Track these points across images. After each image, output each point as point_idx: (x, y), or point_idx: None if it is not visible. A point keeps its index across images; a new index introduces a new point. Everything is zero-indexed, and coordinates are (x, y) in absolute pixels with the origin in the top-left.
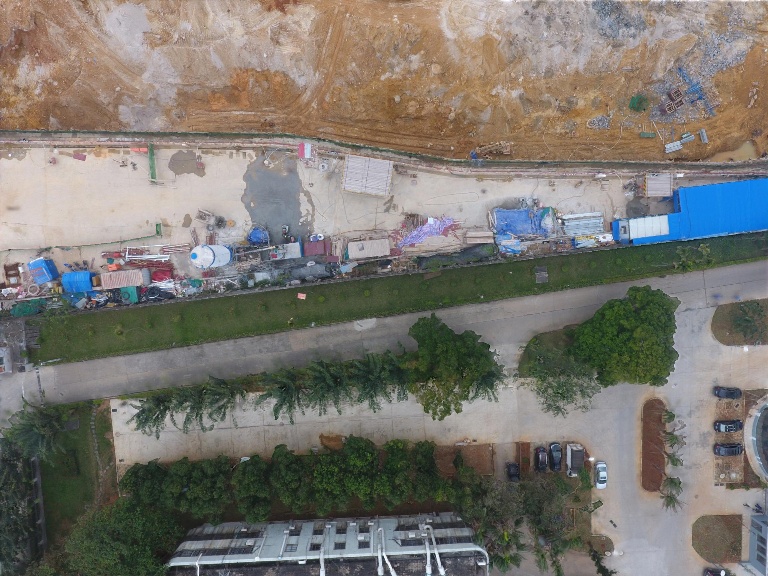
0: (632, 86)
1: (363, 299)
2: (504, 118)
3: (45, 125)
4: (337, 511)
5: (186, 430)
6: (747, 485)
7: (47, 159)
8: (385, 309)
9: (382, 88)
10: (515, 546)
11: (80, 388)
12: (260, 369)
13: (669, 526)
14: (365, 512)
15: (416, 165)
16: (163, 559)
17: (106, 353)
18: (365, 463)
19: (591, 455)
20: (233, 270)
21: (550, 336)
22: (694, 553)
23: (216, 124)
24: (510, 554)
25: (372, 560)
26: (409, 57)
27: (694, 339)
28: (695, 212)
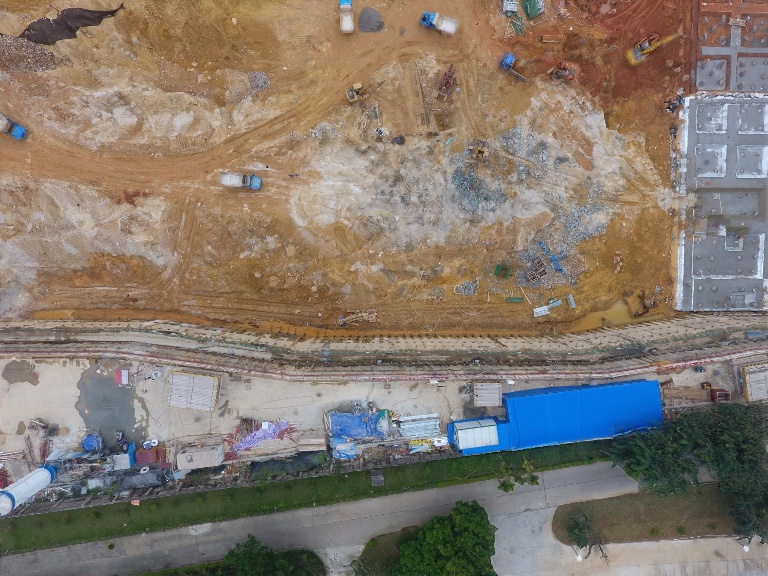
0: (496, 255)
1: (197, 504)
2: (367, 290)
3: None
4: None
5: None
6: None
7: None
8: (220, 514)
9: (240, 267)
10: None
11: None
12: (95, 574)
13: None
14: None
15: (248, 372)
16: None
17: None
18: None
19: None
20: (66, 477)
21: (388, 538)
22: None
23: (79, 299)
24: None
25: None
26: (266, 238)
27: (535, 539)
28: (524, 422)
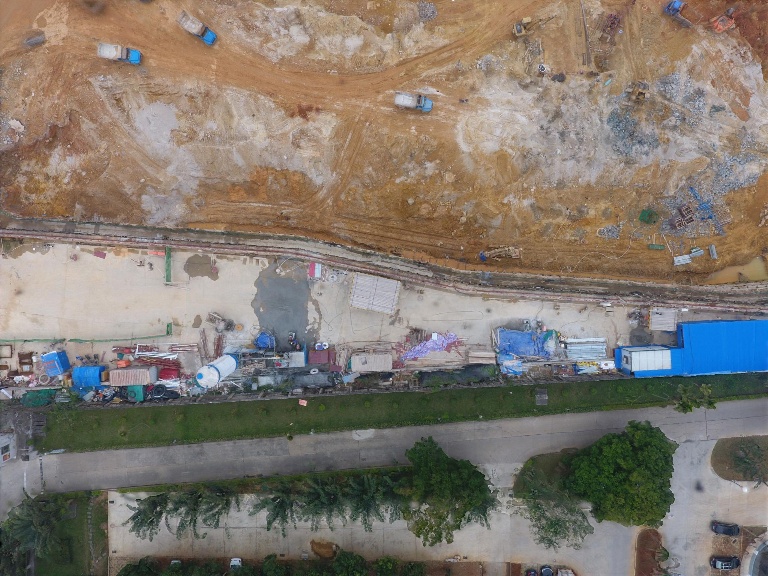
0: (643, 200)
1: (363, 409)
2: (514, 224)
3: (70, 212)
4: None
5: (179, 536)
6: None
7: (69, 255)
8: (384, 421)
9: (396, 191)
10: None
11: (80, 478)
12: (257, 471)
13: None
14: None
15: (423, 282)
16: None
17: (108, 446)
18: None
19: None
20: (238, 373)
21: (547, 458)
22: None
23: (234, 214)
24: None
25: None
26: (425, 164)
27: (693, 471)
28: (698, 349)
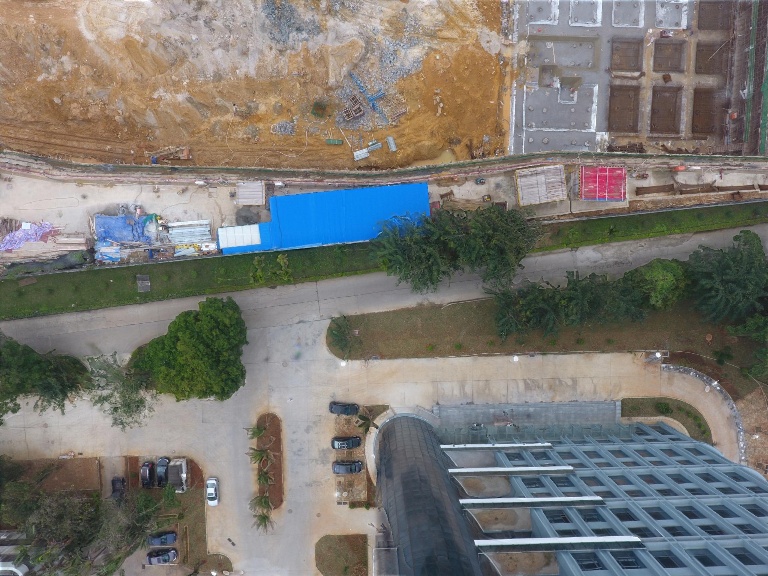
0: (311, 92)
1: None
2: (175, 122)
3: None
4: None
5: None
6: (368, 504)
7: None
8: None
9: (37, 89)
10: (70, 565)
11: None
12: None
13: (291, 545)
14: None
15: None
16: None
17: None
18: None
19: (204, 470)
20: None
21: None
22: (318, 573)
23: None
24: (51, 574)
25: None
26: (61, 58)
27: (308, 352)
28: (286, 222)
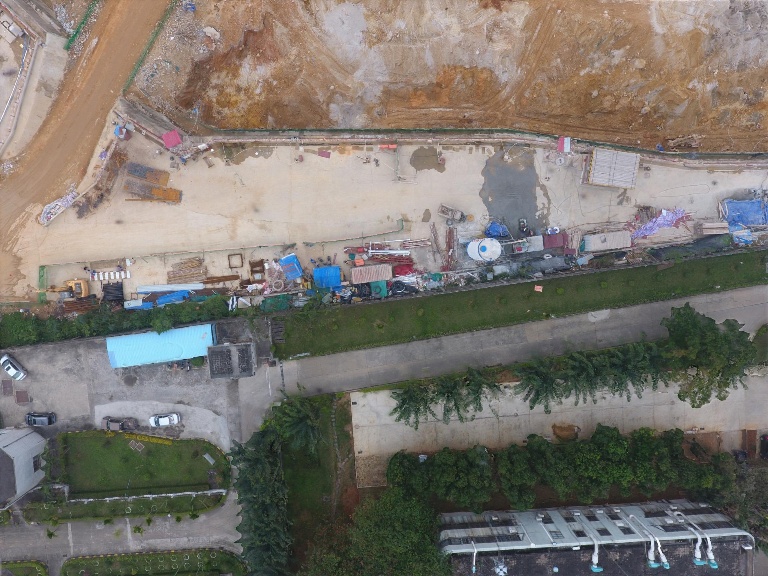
0: None
1: (598, 291)
2: (696, 111)
3: (264, 124)
4: (568, 500)
5: (447, 421)
6: None
7: (293, 157)
8: (619, 300)
9: (582, 83)
10: None
11: (322, 382)
12: (496, 361)
13: None
14: (595, 500)
15: (652, 158)
16: (437, 547)
17: (349, 347)
18: (624, 451)
19: None
20: (472, 264)
21: None
22: None
23: (415, 121)
24: None
25: (639, 546)
26: (611, 52)
27: None
28: None
